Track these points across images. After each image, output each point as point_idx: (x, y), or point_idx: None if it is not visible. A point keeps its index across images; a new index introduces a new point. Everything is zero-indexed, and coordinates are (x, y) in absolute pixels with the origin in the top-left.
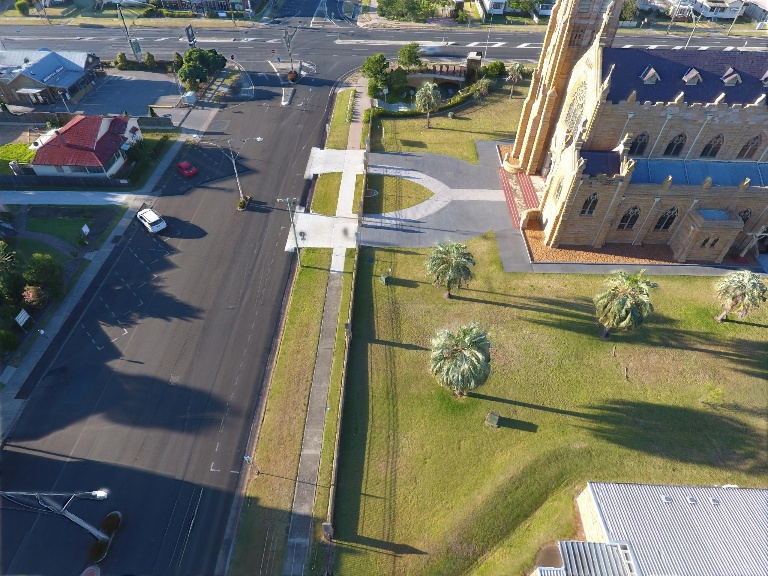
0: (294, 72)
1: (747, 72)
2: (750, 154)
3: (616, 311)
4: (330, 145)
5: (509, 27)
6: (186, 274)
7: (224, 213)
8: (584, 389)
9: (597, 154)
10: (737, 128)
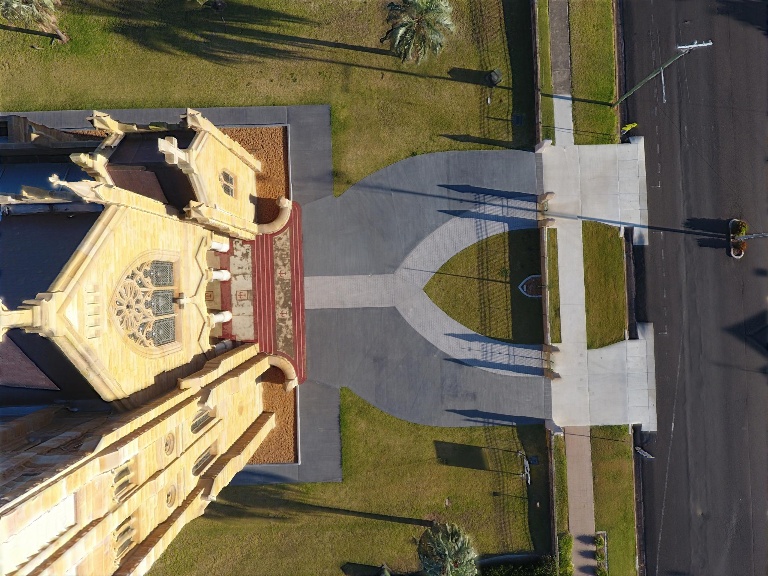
0: None
1: None
2: None
3: None
4: (624, 440)
5: None
6: (767, 75)
7: (760, 211)
8: None
9: (152, 160)
10: None
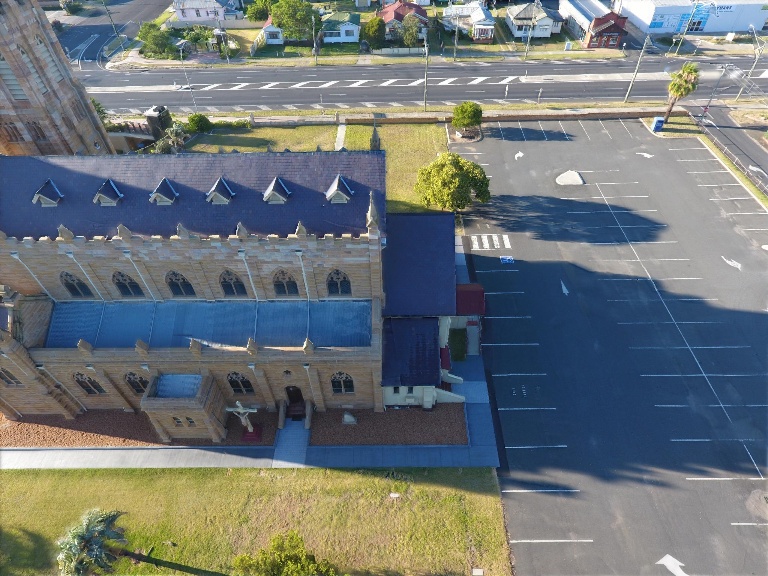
0: None
1: (188, 184)
2: (241, 290)
3: None
4: None
5: (276, 61)
6: None
7: None
8: None
9: None
10: (185, 264)
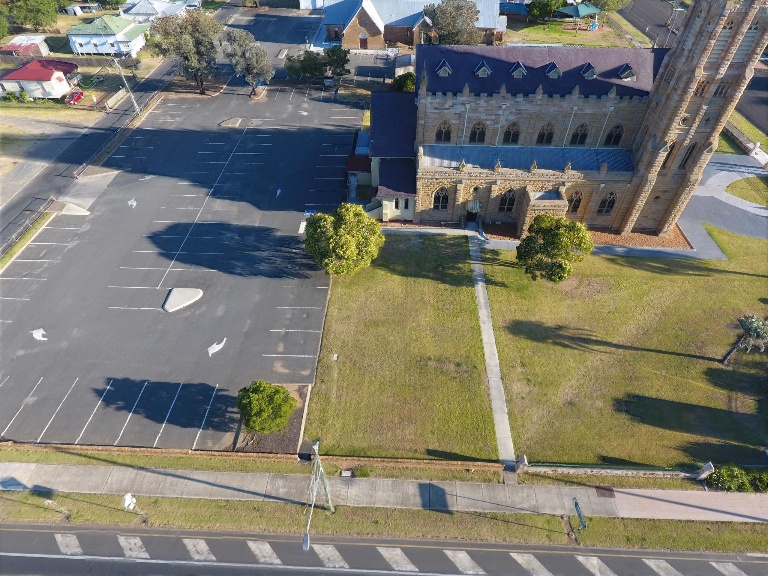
0: None
1: None
2: None
3: None
4: None
5: None
6: None
7: None
8: None
9: None
10: None
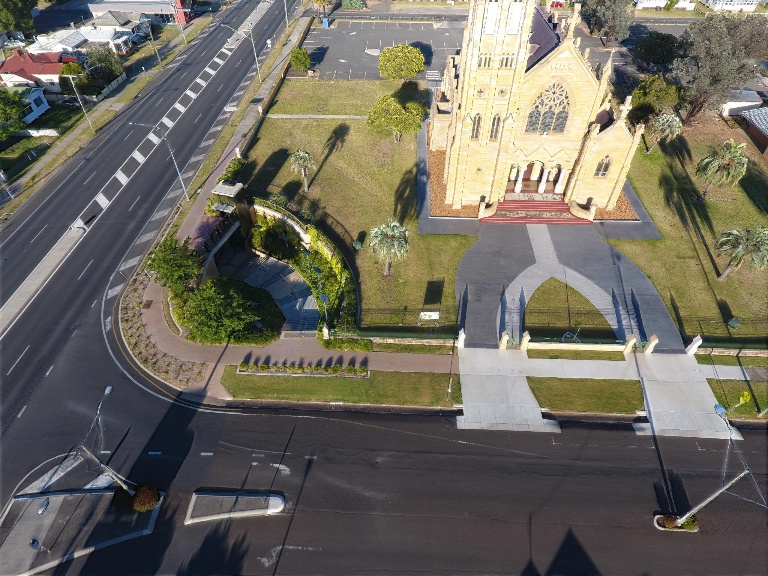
0: (131, 491)
1: None
2: None
3: (741, 171)
4: (448, 399)
5: (49, 160)
6: None
7: (720, 557)
8: (760, 219)
9: None
10: None
